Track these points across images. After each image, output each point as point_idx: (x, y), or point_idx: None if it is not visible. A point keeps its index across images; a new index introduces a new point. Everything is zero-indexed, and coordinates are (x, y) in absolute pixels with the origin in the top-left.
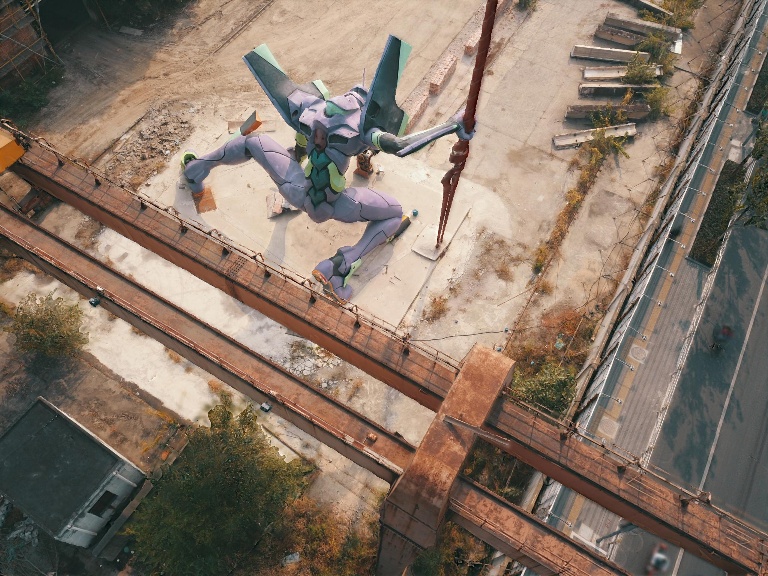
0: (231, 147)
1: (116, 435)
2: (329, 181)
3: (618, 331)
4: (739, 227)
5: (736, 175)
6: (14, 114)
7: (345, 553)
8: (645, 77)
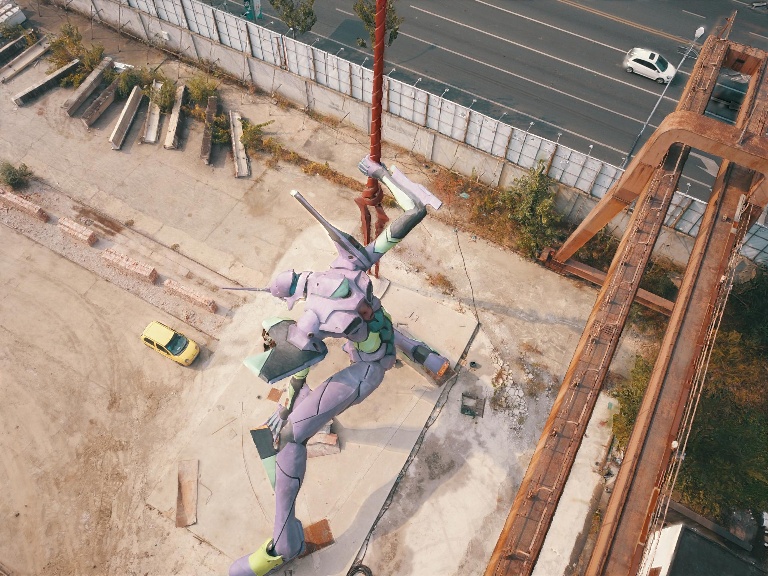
0: (295, 466)
1: None
2: (389, 321)
3: None
4: None
5: None
6: None
7: None
8: None
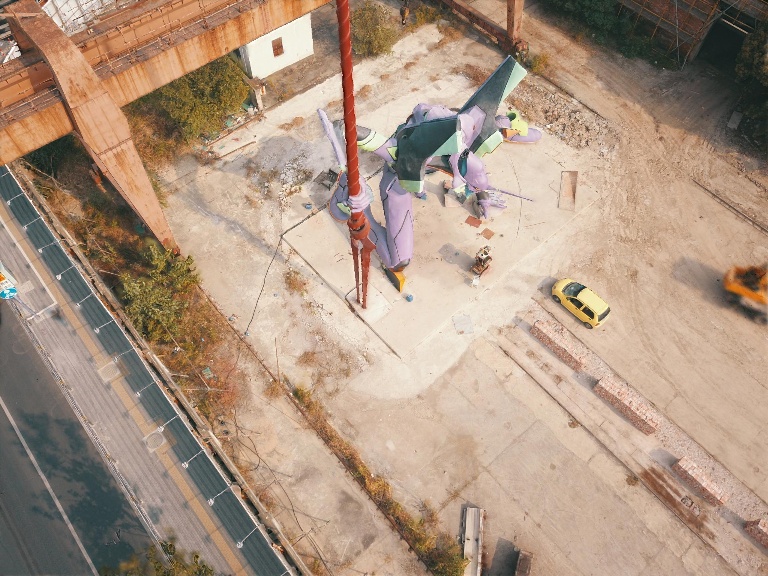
0: None
1: (291, 72)
2: None
3: None
4: None
5: None
6: (617, 38)
7: None
8: None
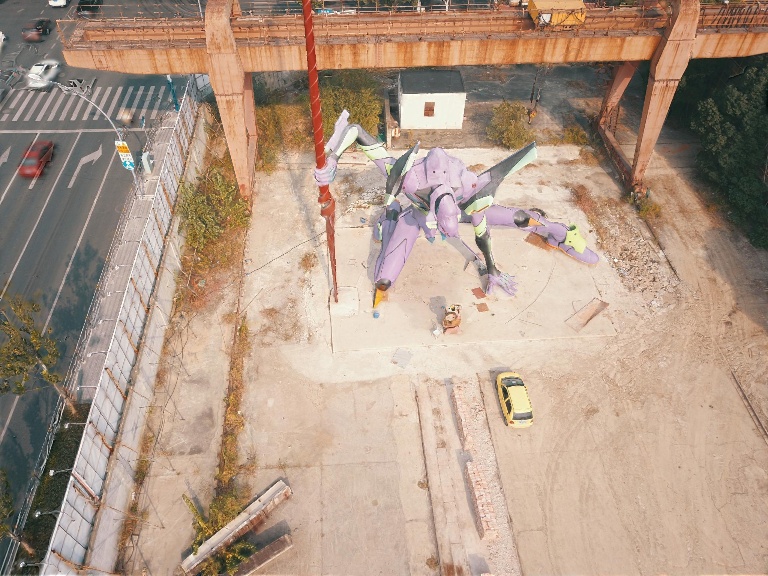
0: None
1: (433, 133)
2: None
3: None
4: None
5: None
6: None
7: None
8: None
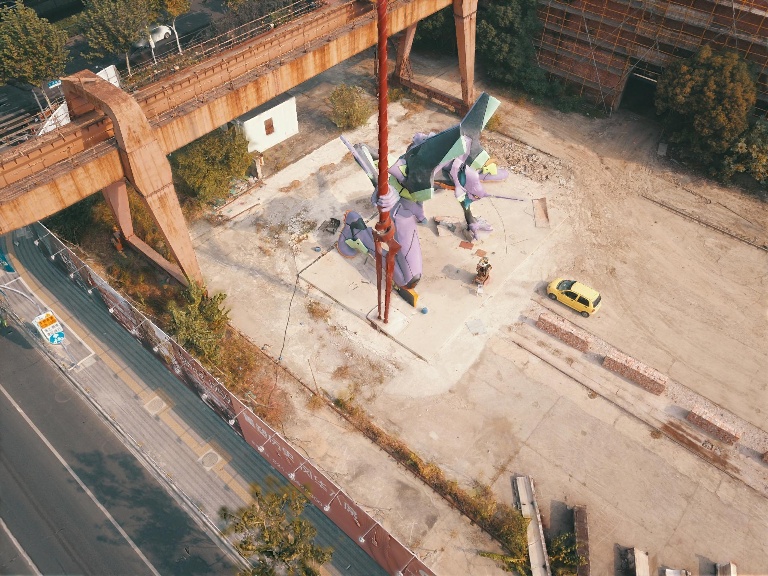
0: None
1: (281, 148)
2: None
3: None
4: None
5: None
6: (552, 100)
7: None
8: None
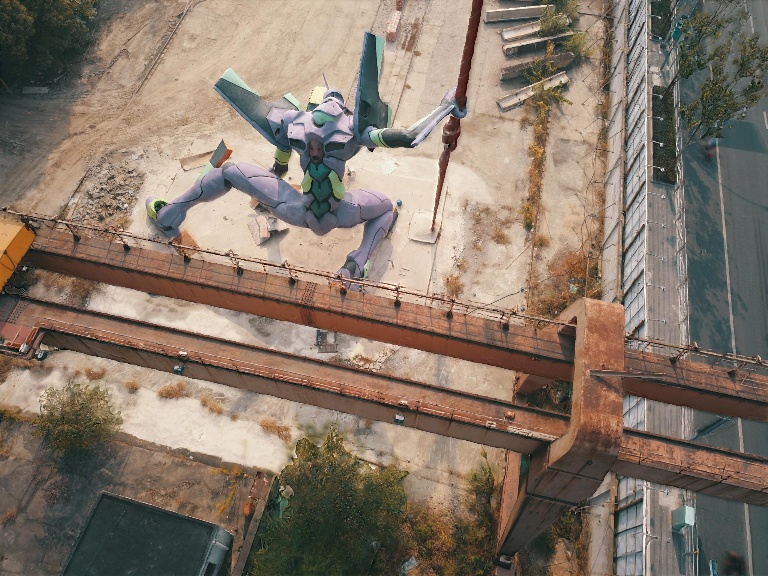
0: (208, 182)
1: (184, 506)
2: (332, 190)
3: (635, 260)
4: (696, 141)
5: (666, 97)
6: None
7: (458, 542)
8: (559, 27)
